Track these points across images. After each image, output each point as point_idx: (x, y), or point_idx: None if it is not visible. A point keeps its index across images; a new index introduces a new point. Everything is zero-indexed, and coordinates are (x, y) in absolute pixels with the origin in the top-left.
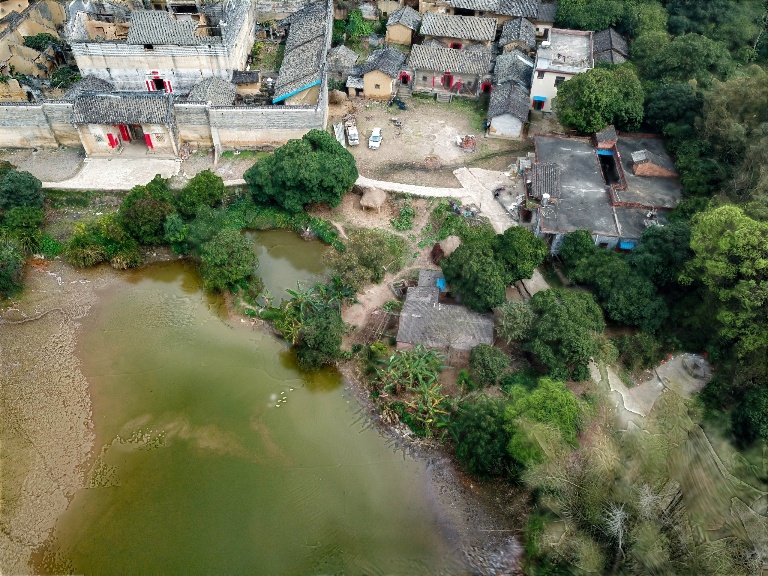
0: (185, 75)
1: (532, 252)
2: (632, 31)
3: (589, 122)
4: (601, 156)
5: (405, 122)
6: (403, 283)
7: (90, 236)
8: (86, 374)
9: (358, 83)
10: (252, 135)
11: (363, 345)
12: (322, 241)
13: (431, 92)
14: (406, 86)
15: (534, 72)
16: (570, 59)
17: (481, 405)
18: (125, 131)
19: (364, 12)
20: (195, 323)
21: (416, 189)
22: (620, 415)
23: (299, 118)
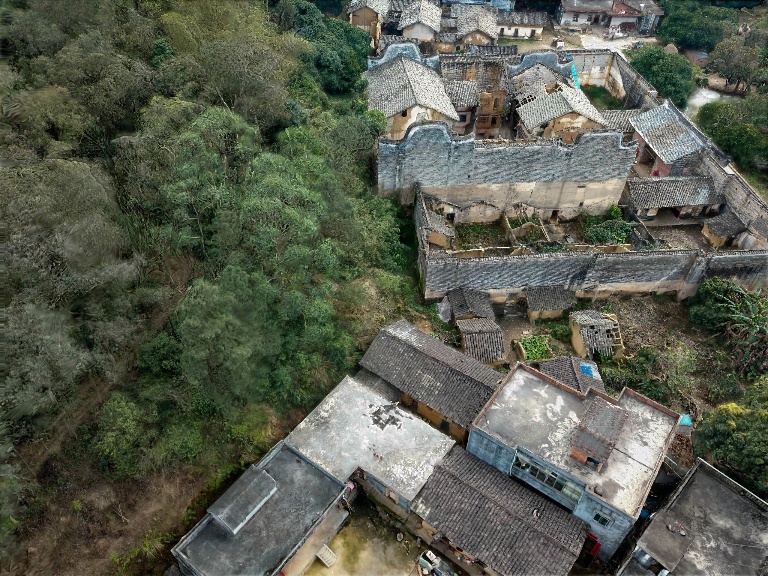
0: None
1: None
2: None
3: None
4: None
5: None
6: None
7: None
8: None
9: None
10: None
11: None
12: None
13: None
14: None
15: None
16: None
17: None
18: None
19: None
20: None
21: None
22: None
23: None
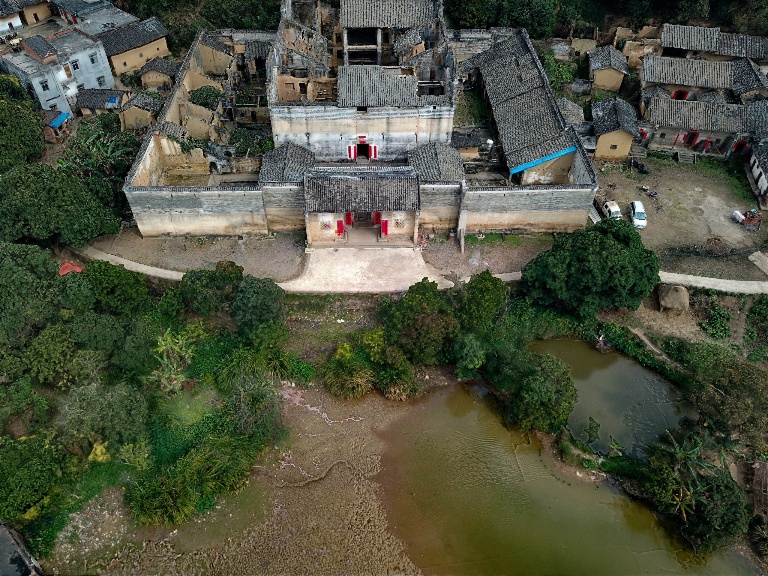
0: (396, 139)
1: None
2: None
3: None
4: None
5: (657, 191)
6: None
7: (354, 359)
8: (418, 564)
9: (588, 143)
10: (505, 217)
11: (762, 515)
12: (623, 354)
13: (670, 151)
14: (639, 144)
15: None
16: None
17: None
18: (351, 214)
19: (556, 52)
20: (520, 479)
21: (719, 283)
22: None
23: (569, 198)
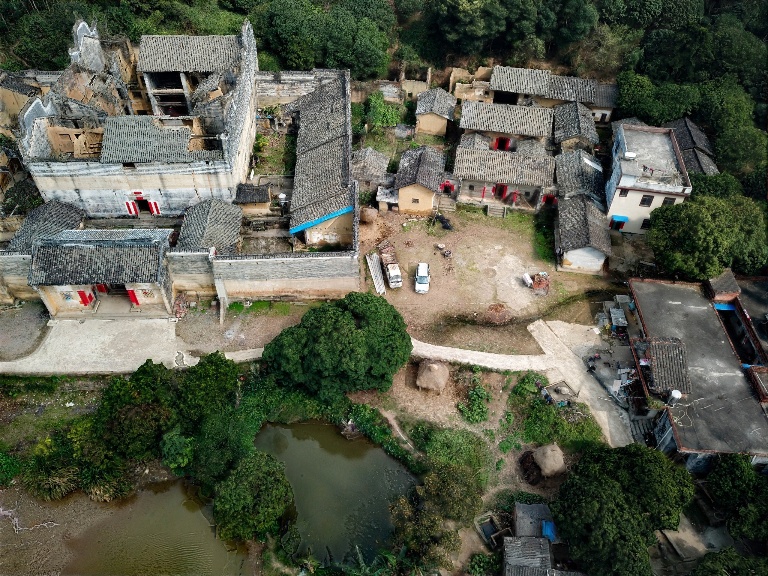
0: (176, 195)
1: (676, 492)
2: (713, 122)
3: (703, 268)
4: (720, 311)
5: (454, 249)
6: (490, 517)
7: (57, 454)
8: None
9: (391, 196)
10: (268, 285)
11: None
12: (370, 440)
13: (480, 204)
14: (448, 196)
15: (615, 189)
16: (660, 173)
17: None
18: None
19: (386, 94)
20: None
21: (486, 358)
22: None
23: (330, 266)
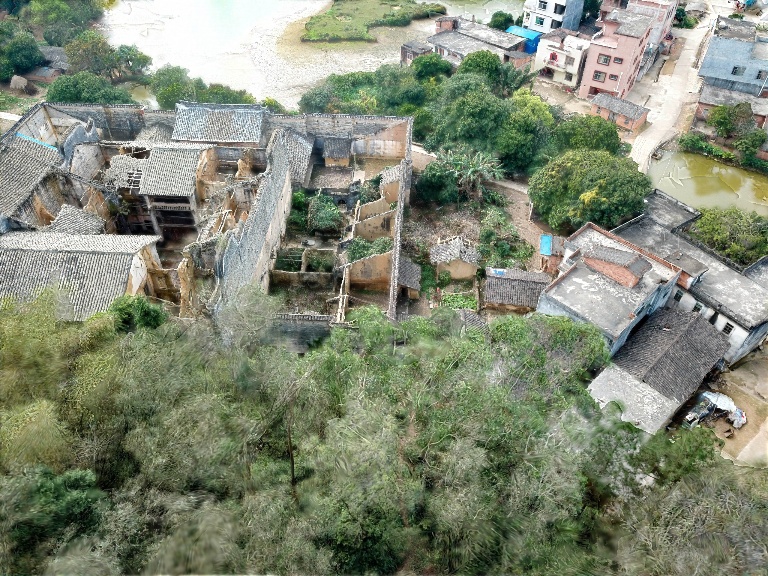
0: None
1: None
2: None
3: None
4: None
5: None
6: None
7: (264, 104)
8: None
9: None
10: None
11: None
12: None
13: None
14: None
15: None
16: None
17: (72, 13)
18: None
19: None
20: None
21: (7, 116)
22: (21, 1)
23: None
